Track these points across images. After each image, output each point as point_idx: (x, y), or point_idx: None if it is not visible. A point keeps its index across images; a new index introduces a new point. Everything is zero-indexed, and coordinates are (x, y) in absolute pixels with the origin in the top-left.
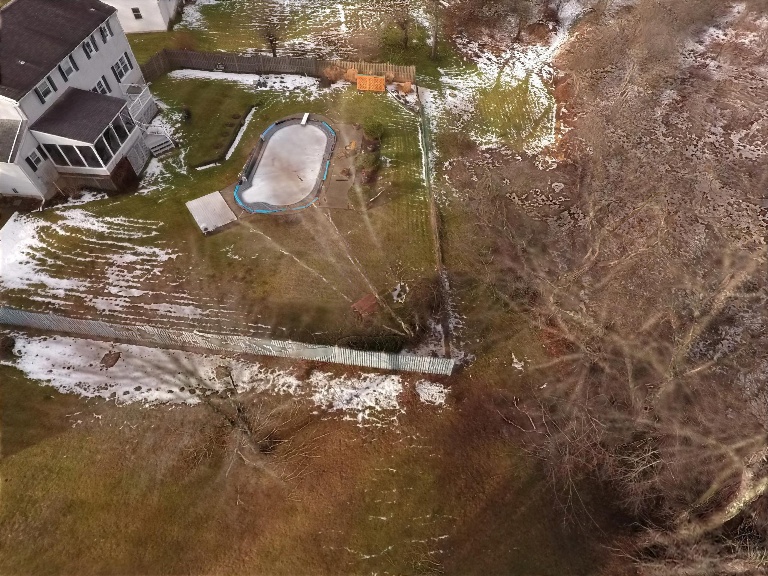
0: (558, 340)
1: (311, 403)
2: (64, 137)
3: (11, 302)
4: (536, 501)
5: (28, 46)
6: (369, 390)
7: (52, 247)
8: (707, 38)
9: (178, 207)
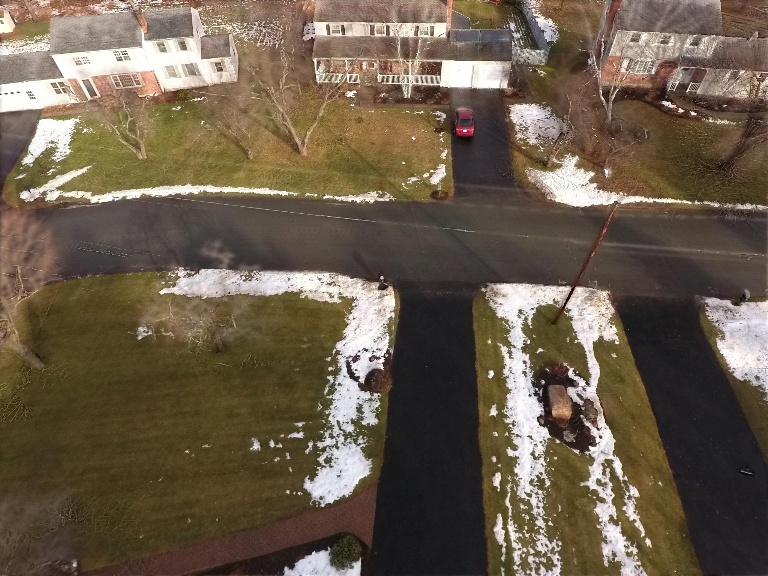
0: None
1: None
2: None
3: None
4: None
5: None
6: None
7: None
8: None
9: None
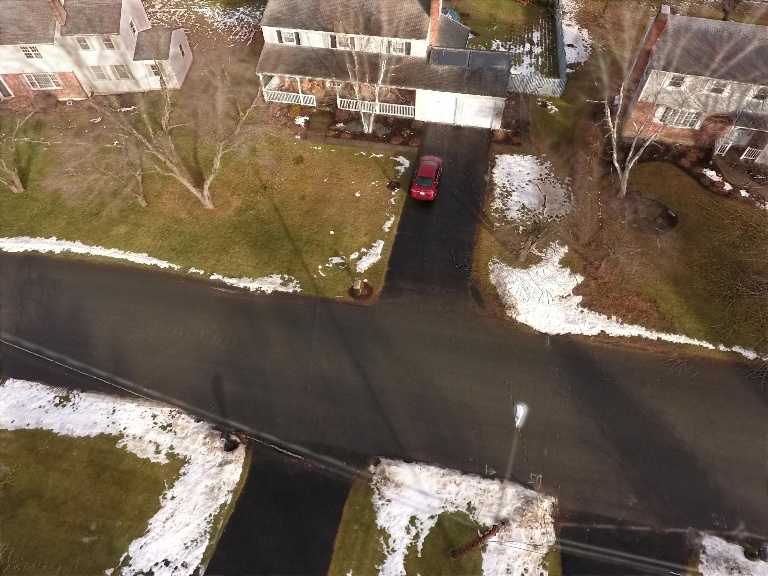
0: None
1: None
2: None
3: (545, 68)
4: None
5: None
6: (568, 3)
7: None
8: None
9: None
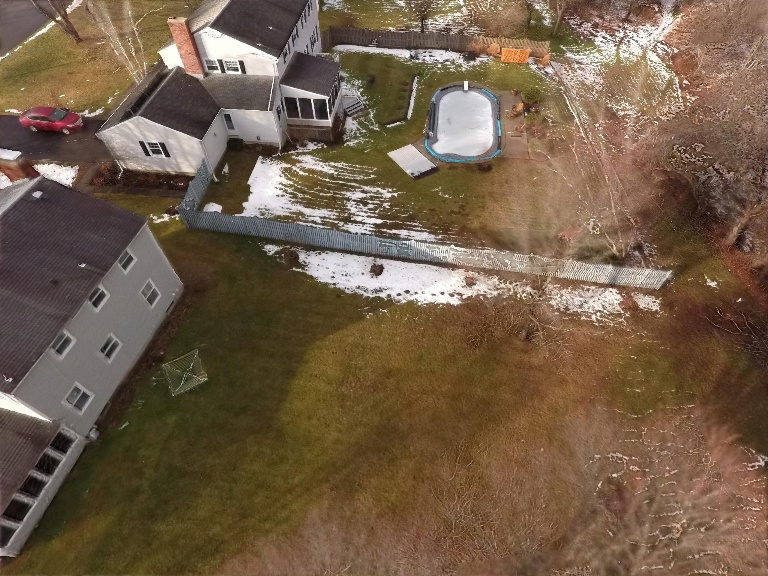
0: (741, 266)
1: (551, 306)
2: (307, 91)
3: None
4: (758, 384)
5: (269, 15)
6: (594, 298)
7: (298, 184)
8: None
9: (383, 156)
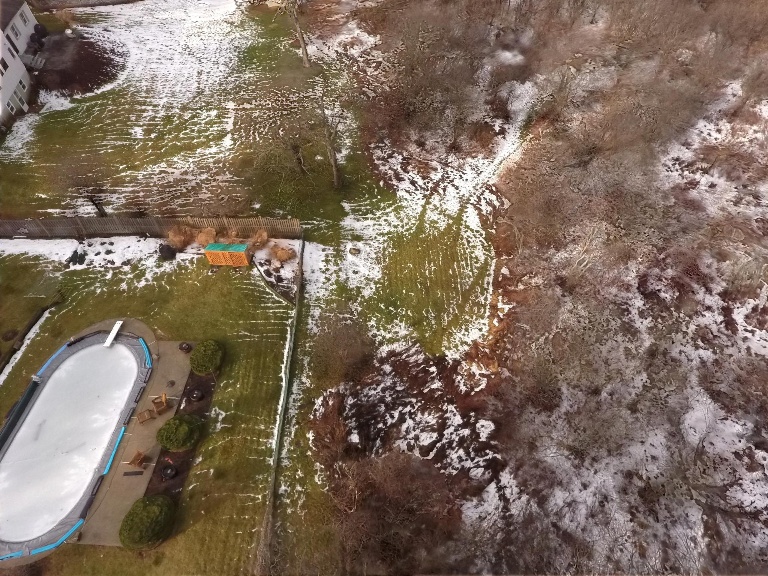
0: None
1: None
2: None
3: None
4: None
5: None
6: None
7: None
8: (696, 137)
9: None
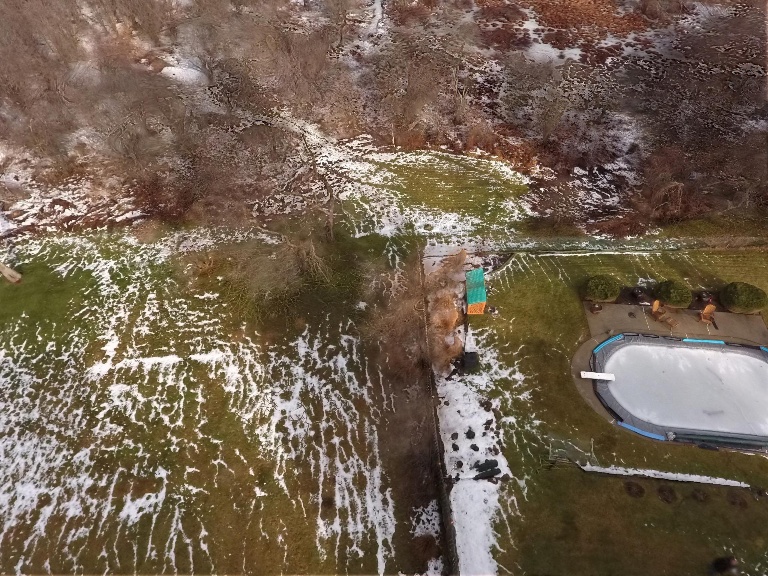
0: None
1: None
2: None
3: None
4: None
5: None
6: None
7: None
8: None
9: None
